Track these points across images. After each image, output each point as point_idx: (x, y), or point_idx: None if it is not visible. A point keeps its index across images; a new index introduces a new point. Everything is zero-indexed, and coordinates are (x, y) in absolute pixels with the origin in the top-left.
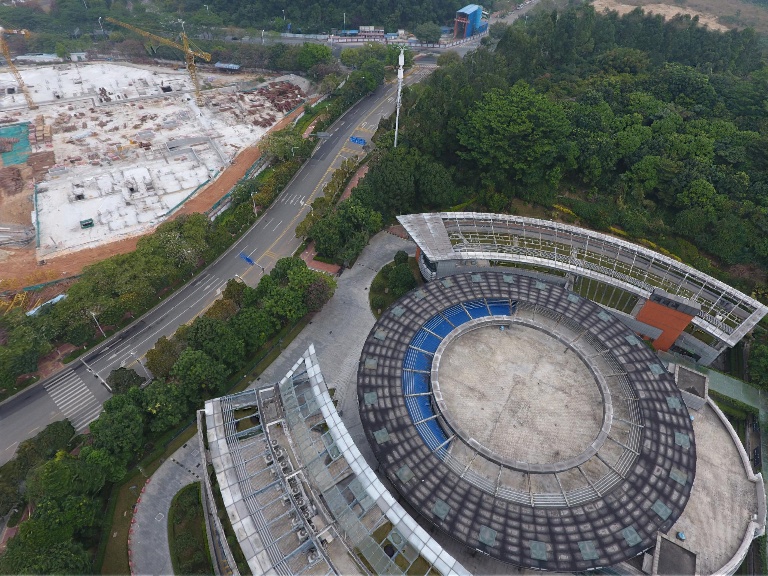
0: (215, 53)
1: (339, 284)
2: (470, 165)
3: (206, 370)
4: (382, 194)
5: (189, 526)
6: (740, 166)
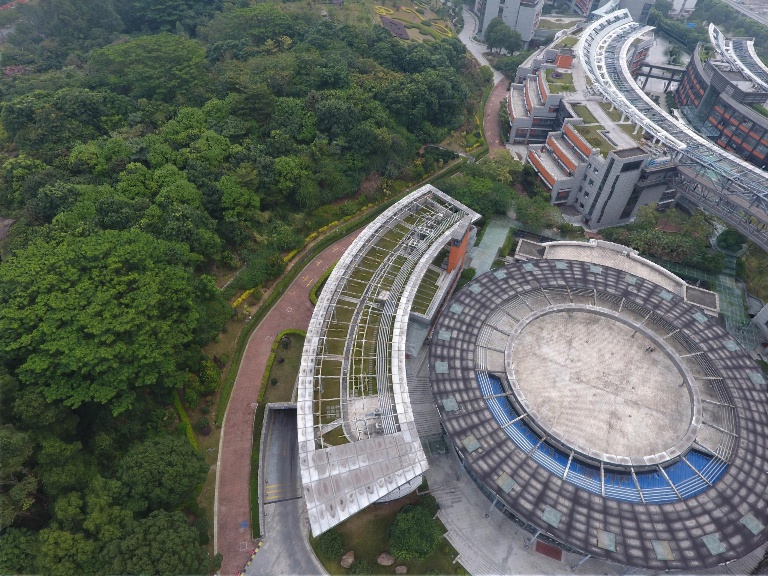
0: None
1: None
2: None
3: None
4: None
5: None
6: (251, 131)
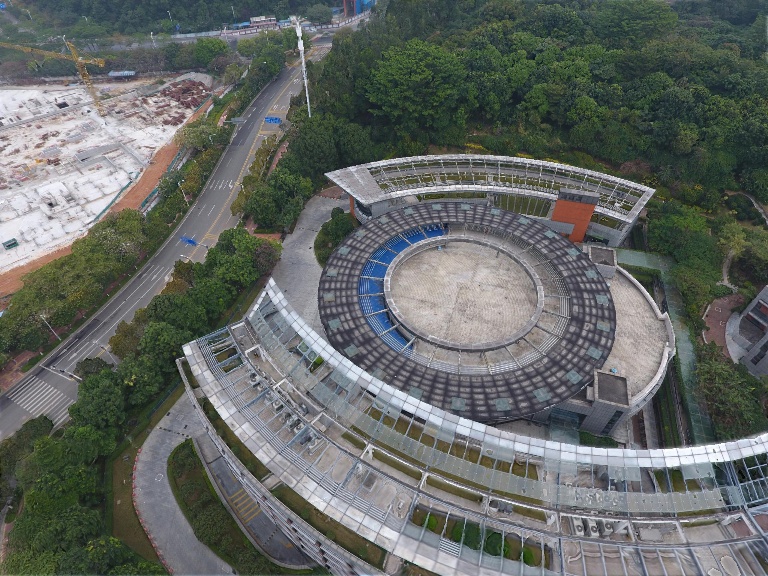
0: (106, 62)
1: (284, 249)
2: (384, 122)
3: (174, 337)
4: (307, 160)
5: (190, 476)
6: (613, 80)
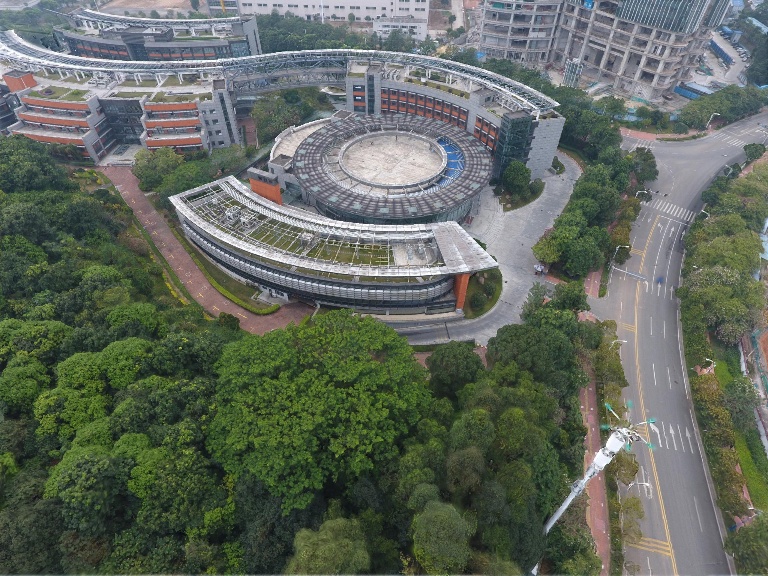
0: None
1: None
2: None
3: (586, 171)
4: None
5: None
6: None
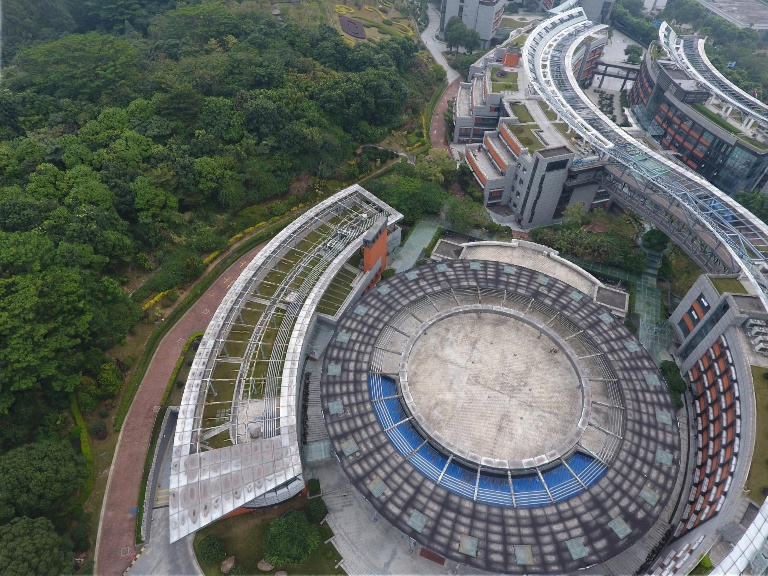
0: None
1: None
2: None
3: None
4: None
5: None
6: (177, 131)
